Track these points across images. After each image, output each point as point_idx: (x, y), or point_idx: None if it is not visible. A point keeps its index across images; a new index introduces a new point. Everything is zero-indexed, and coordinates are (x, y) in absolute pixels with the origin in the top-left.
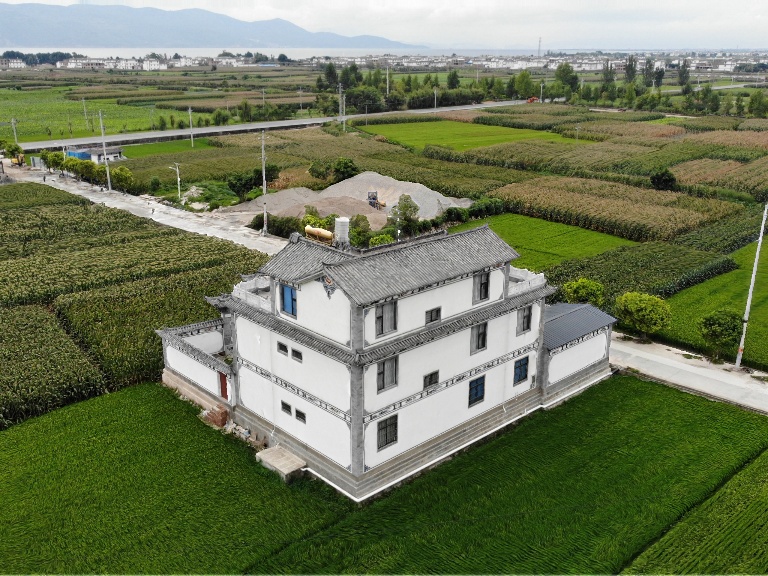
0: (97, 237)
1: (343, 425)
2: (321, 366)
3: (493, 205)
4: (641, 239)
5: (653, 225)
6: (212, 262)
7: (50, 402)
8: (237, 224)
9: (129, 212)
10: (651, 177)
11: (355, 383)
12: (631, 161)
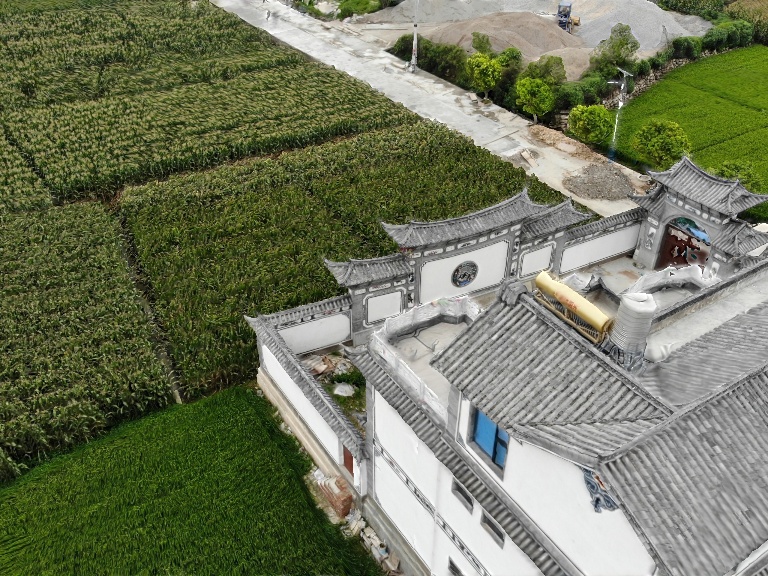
0: (192, 64)
1: None
2: None
3: (738, 32)
4: None
5: None
6: (340, 125)
7: (86, 429)
8: (375, 46)
9: (237, 18)
10: None
11: None
12: None
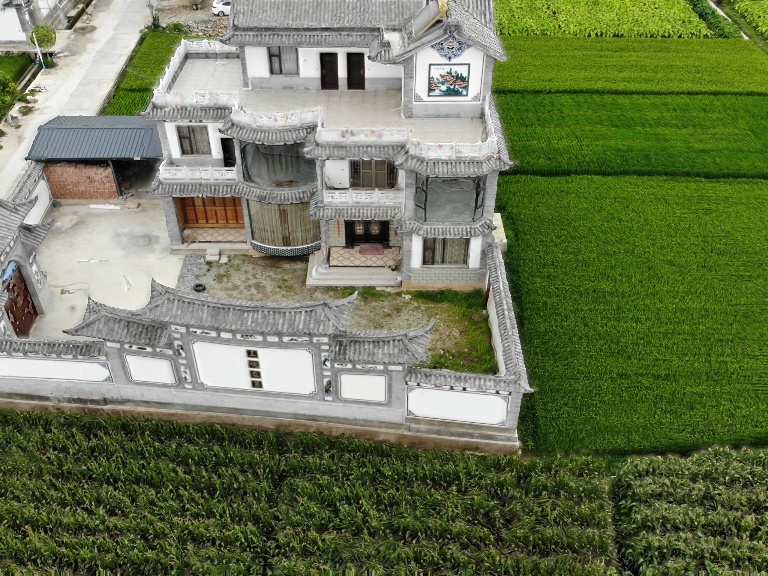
0: None
1: None
2: None
3: None
4: None
5: None
6: None
7: None
8: None
9: None
10: None
11: None
12: None
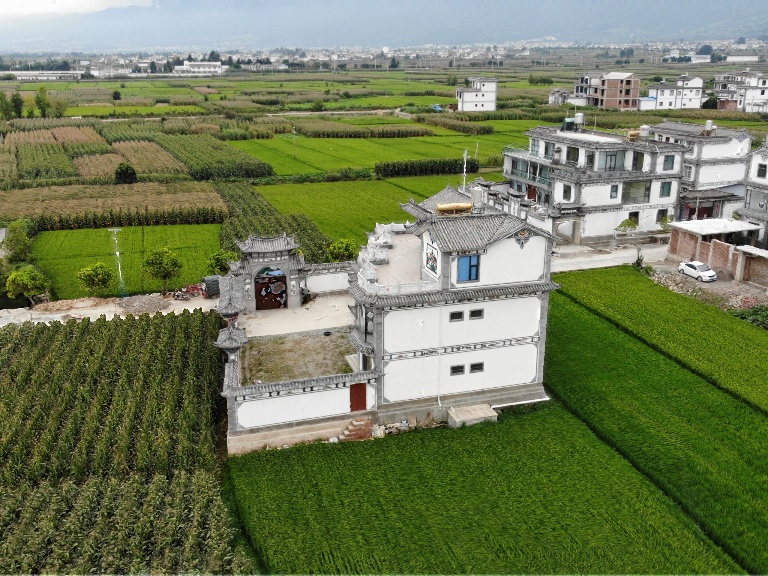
0: None
1: (529, 348)
2: (507, 310)
3: (29, 226)
4: (209, 221)
5: (211, 206)
6: None
7: None
8: None
9: None
10: (117, 173)
11: (546, 306)
12: (35, 166)
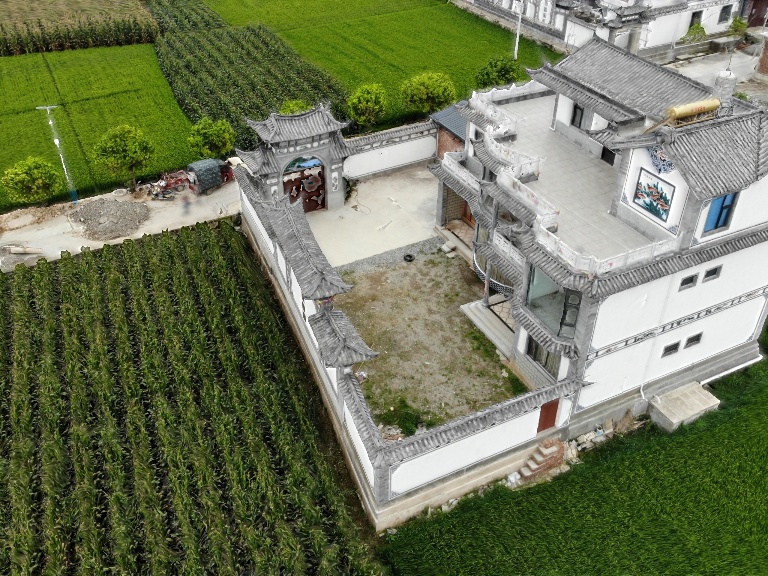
0: None
1: (758, 301)
2: (749, 260)
3: None
4: (133, 39)
5: (133, 18)
6: None
7: None
8: None
9: None
10: None
11: None
12: None
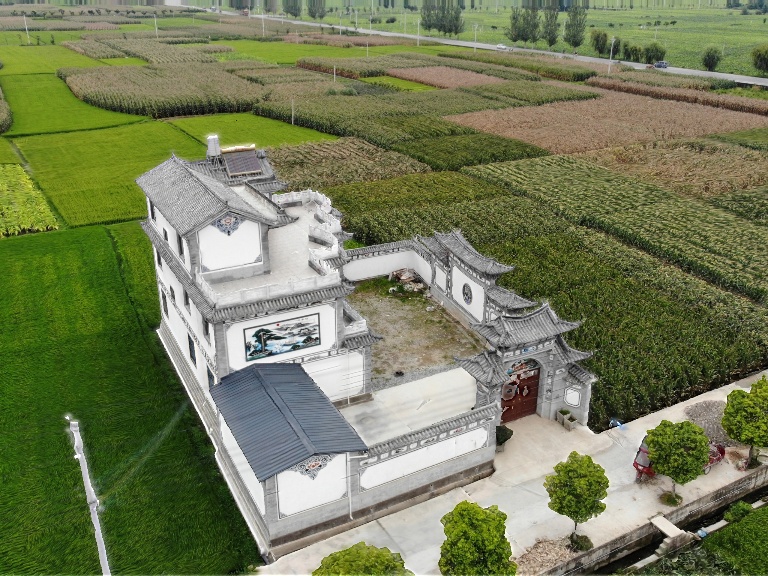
0: None
1: None
2: None
3: None
4: None
5: None
6: (762, 293)
7: None
8: None
9: None
10: None
11: None
12: None
